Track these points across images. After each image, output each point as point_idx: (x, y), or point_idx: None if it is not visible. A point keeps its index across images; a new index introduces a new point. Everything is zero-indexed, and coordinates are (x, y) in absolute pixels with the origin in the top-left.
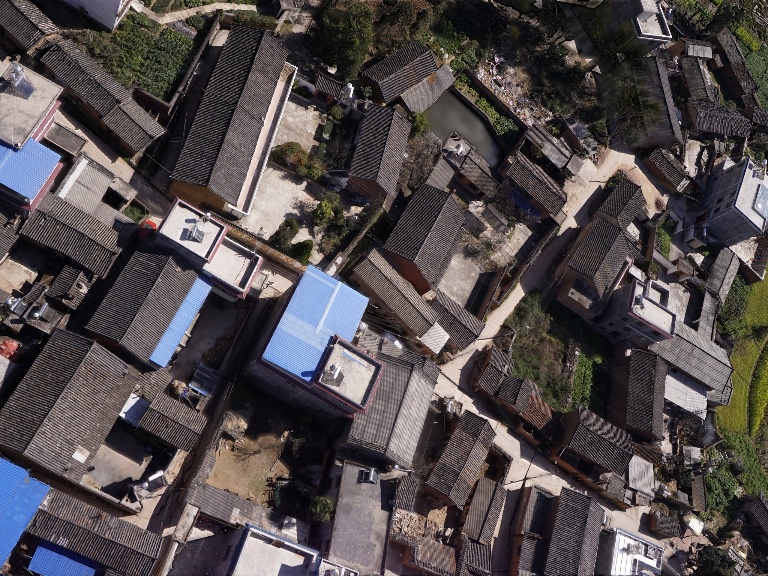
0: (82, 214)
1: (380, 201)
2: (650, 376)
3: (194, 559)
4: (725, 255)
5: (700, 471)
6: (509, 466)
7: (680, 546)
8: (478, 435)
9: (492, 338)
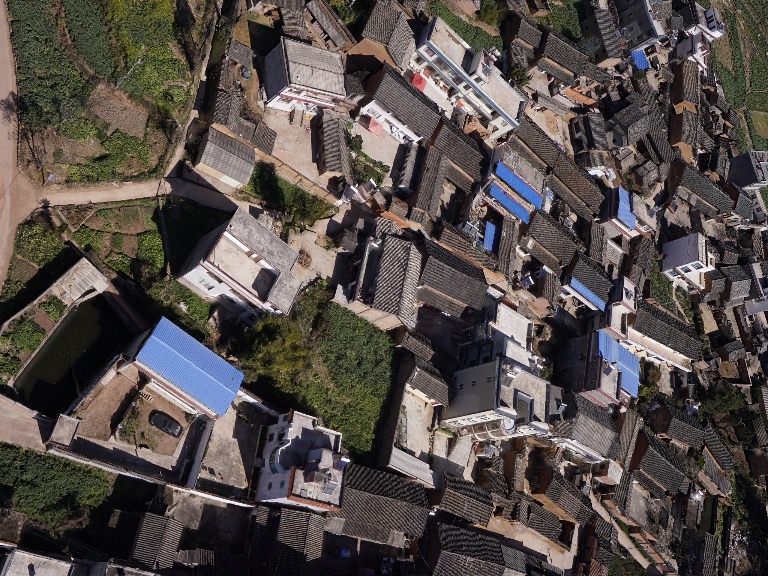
0: (606, 249)
1: (657, 432)
2: None
3: None
4: None
5: None
6: (566, 547)
7: None
8: None
9: None
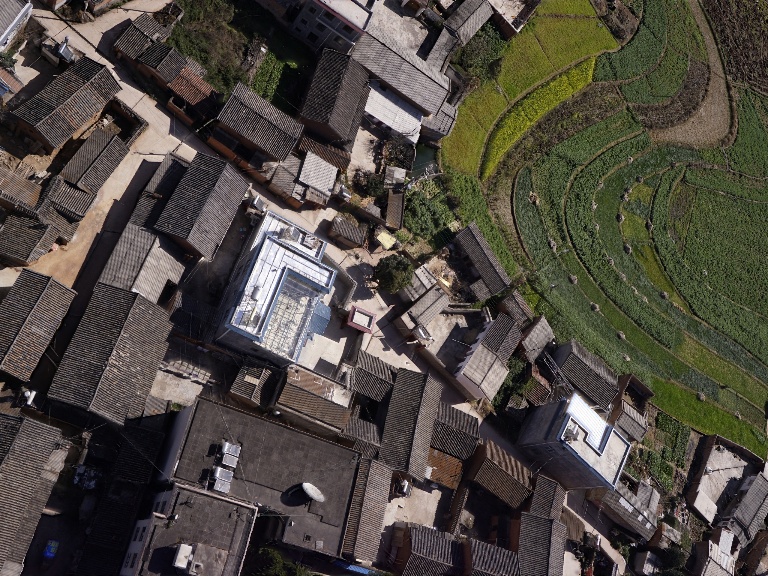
0: None
1: None
2: (339, 74)
3: None
4: None
5: (401, 190)
6: (141, 129)
7: (366, 259)
8: (90, 78)
9: (153, 13)
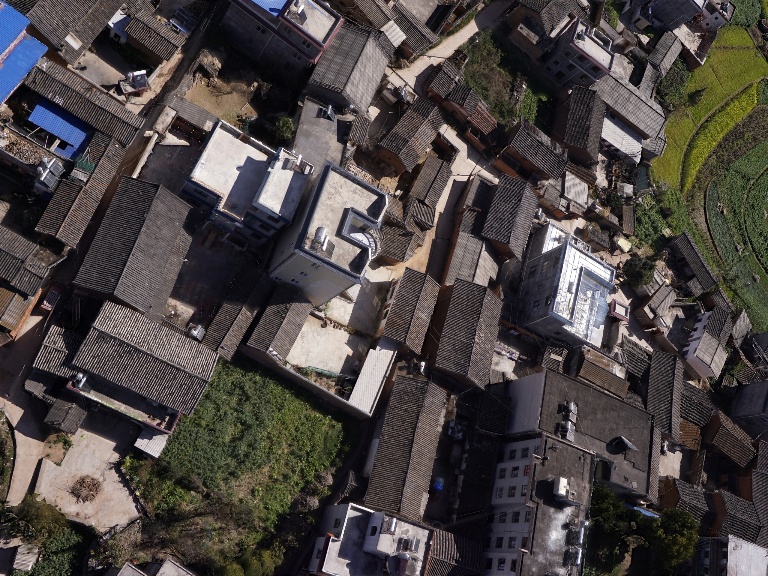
0: None
1: None
2: (588, 107)
3: (172, 159)
4: (668, 37)
5: (631, 203)
6: (455, 155)
7: (609, 261)
8: (428, 115)
9: (446, 58)
